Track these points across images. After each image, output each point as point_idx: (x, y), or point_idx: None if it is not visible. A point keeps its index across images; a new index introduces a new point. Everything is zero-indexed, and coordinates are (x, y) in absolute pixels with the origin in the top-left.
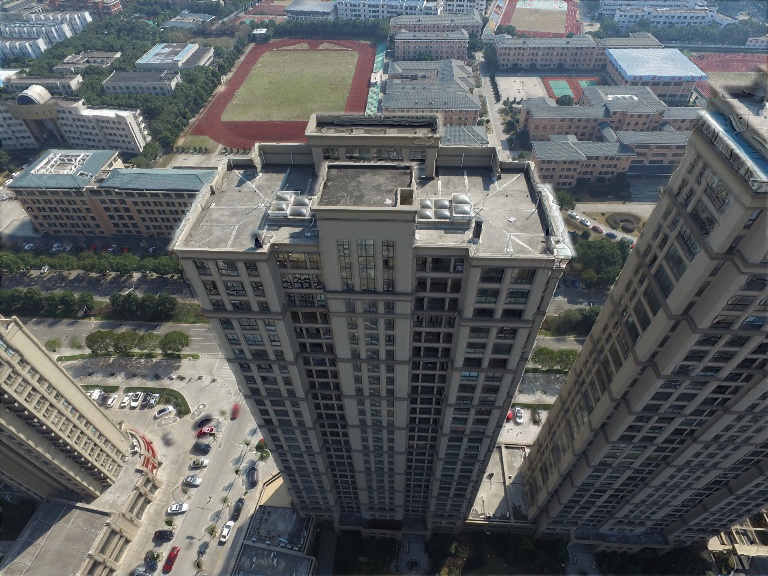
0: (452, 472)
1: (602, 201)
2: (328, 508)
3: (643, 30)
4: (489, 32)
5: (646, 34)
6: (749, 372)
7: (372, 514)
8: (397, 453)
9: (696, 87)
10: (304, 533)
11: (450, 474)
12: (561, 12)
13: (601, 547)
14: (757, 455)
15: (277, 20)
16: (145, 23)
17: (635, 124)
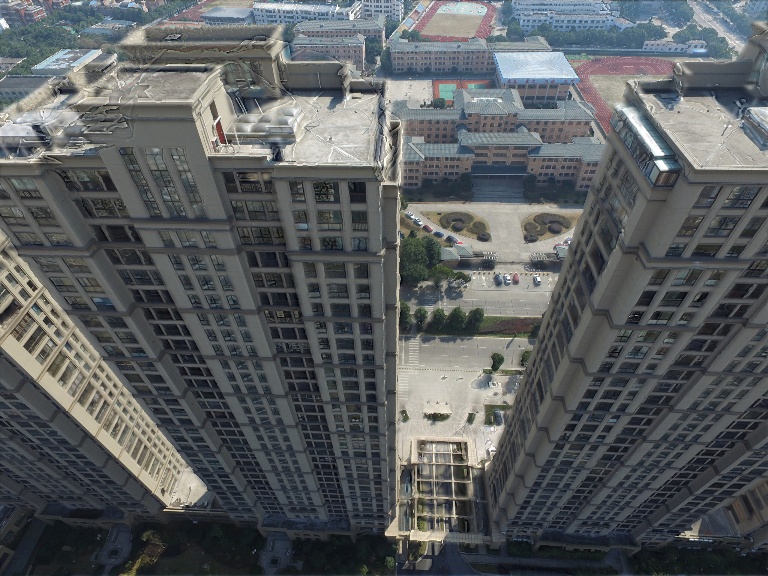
0: (71, 458)
1: (443, 201)
2: (19, 497)
3: (543, 34)
4: (397, 37)
5: (537, 38)
6: (192, 353)
7: (72, 503)
8: (2, 439)
9: (578, 90)
10: (3, 522)
11: (72, 460)
12: (478, 17)
13: (290, 534)
14: (320, 438)
15: (198, 26)
16: (61, 30)
17: (491, 126)
